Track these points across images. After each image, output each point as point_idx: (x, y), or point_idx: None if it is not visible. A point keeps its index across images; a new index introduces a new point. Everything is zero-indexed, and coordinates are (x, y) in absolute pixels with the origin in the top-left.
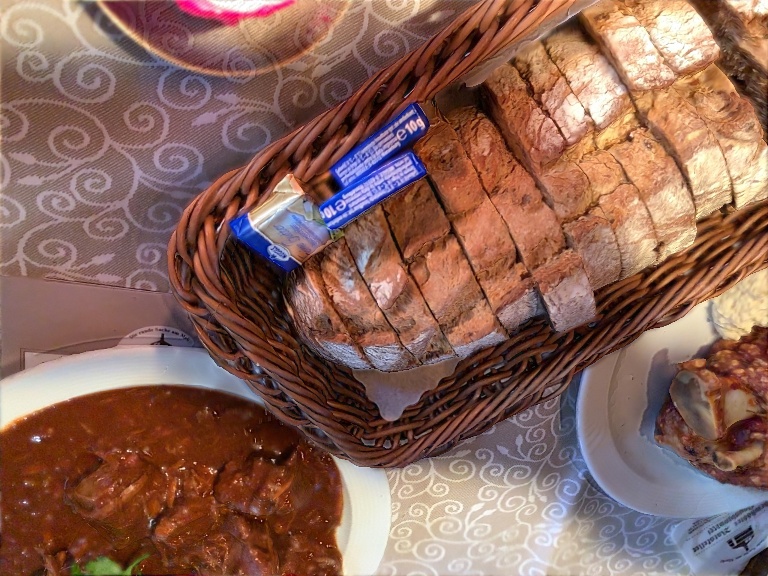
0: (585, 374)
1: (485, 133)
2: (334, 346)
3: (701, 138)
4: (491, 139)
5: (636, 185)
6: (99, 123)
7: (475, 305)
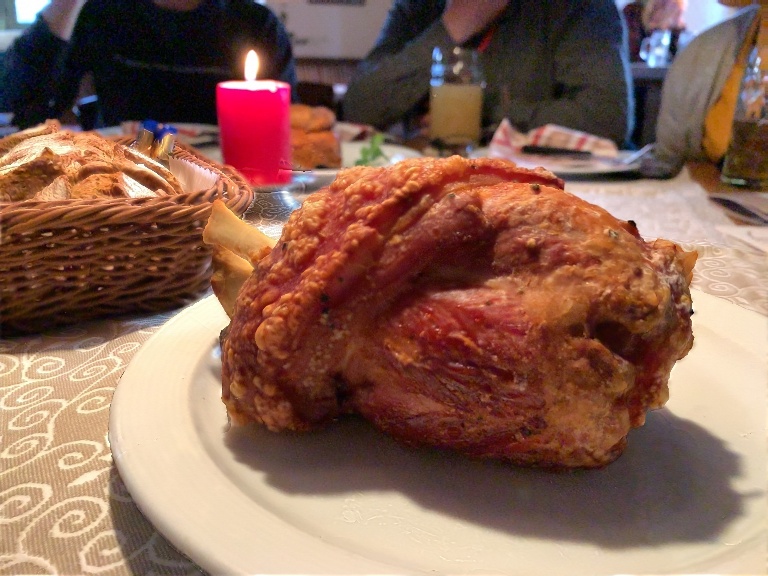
0: None
1: None
2: None
3: None
4: None
5: None
6: None
7: None
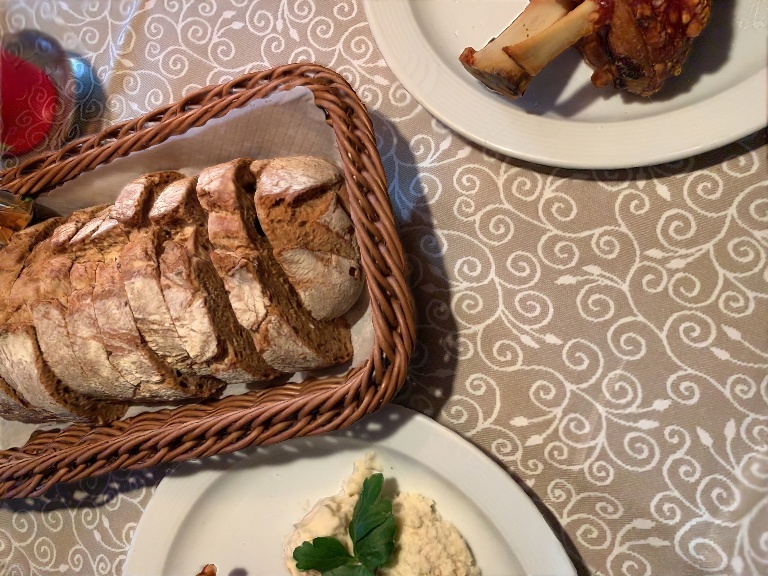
0: (136, 530)
1: None
2: None
3: (141, 267)
4: None
5: (94, 289)
6: None
7: None
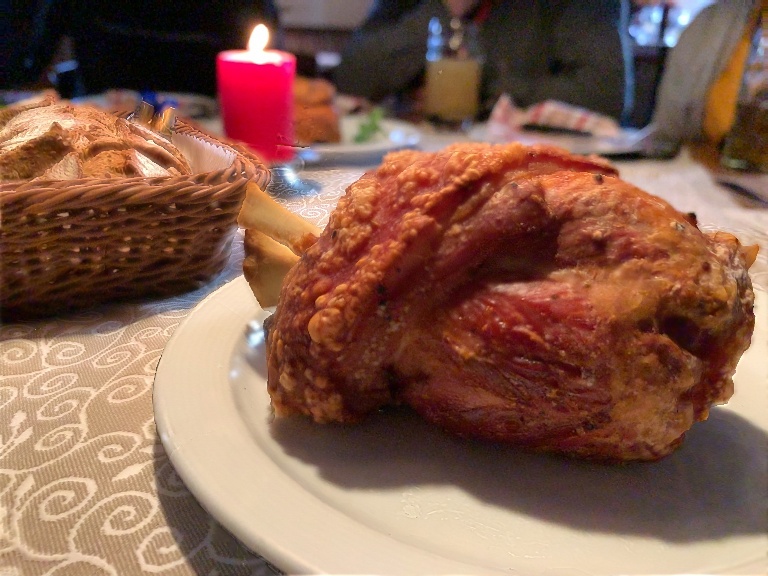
0: None
1: None
2: None
3: (84, 124)
4: None
5: None
6: None
7: None
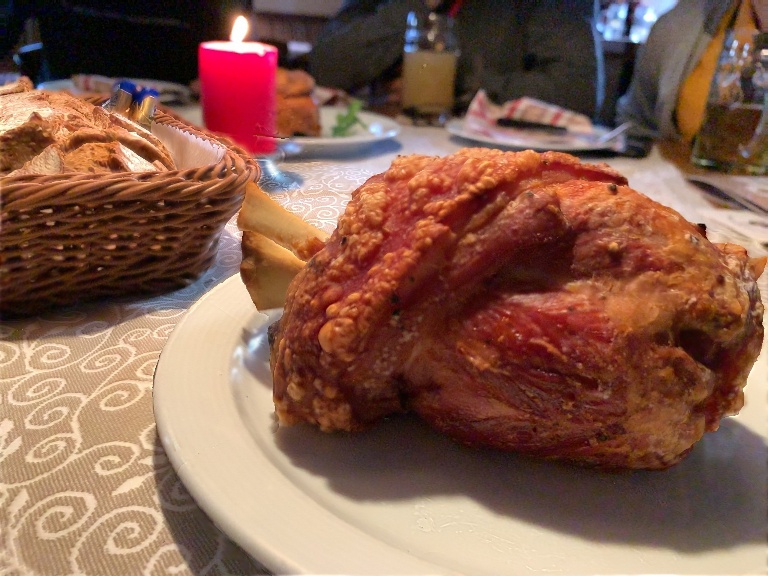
0: None
1: None
2: None
3: (62, 113)
4: None
5: None
6: None
7: None
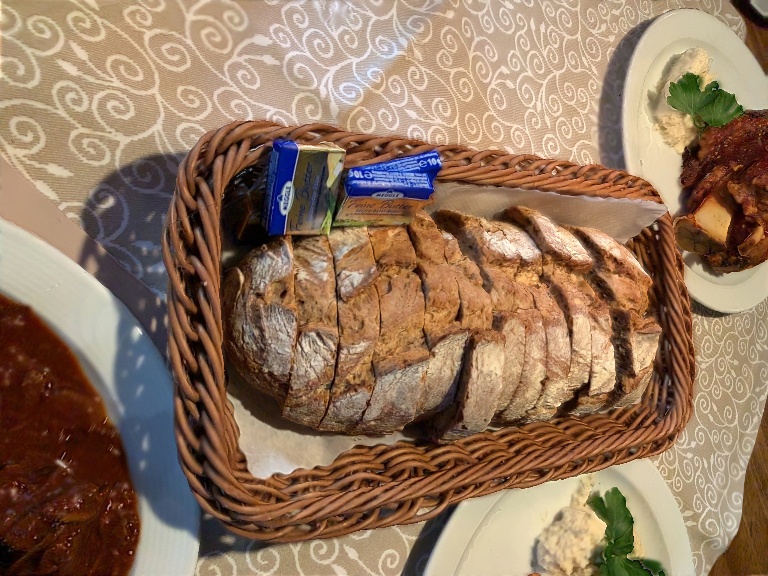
0: (434, 554)
1: (448, 233)
2: (277, 317)
3: (581, 306)
4: (453, 236)
5: (541, 313)
6: (157, 77)
7: (413, 341)
